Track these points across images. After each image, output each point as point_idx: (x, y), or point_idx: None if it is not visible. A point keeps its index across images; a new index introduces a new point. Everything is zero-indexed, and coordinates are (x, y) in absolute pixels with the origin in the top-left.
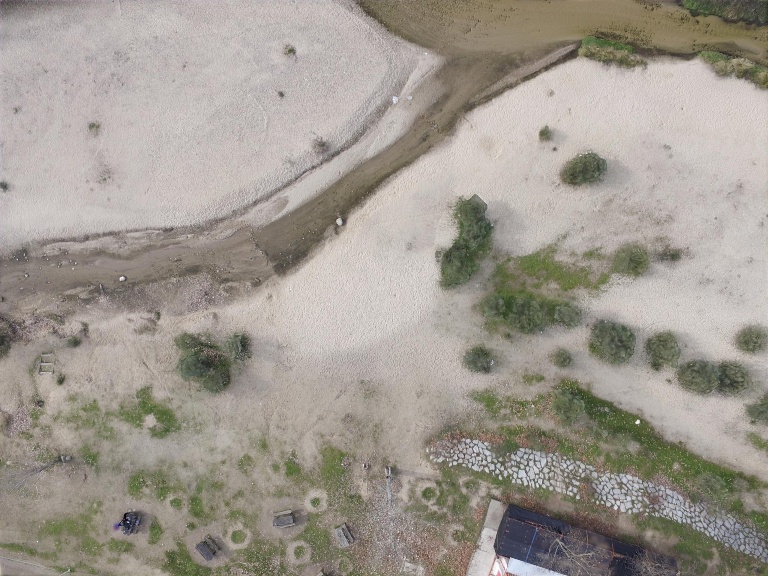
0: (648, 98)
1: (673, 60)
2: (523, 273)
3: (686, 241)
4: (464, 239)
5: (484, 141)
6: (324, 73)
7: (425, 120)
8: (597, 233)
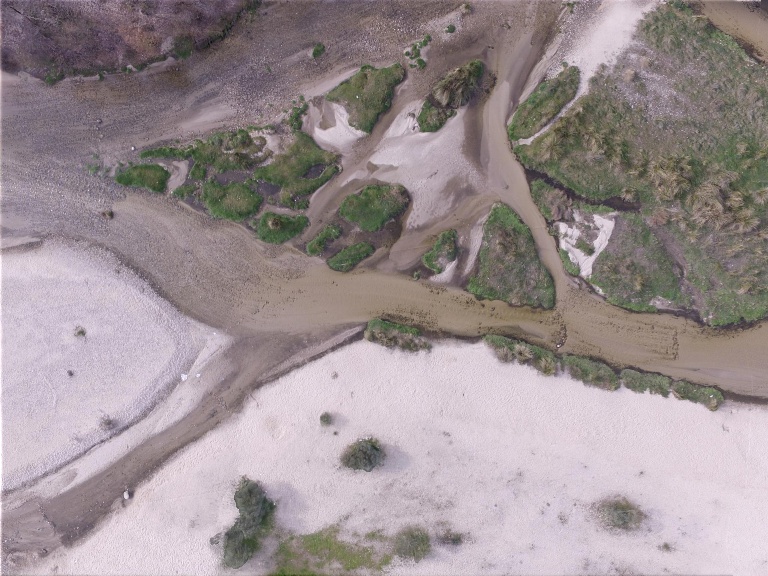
0: (430, 383)
1: (458, 343)
2: (306, 552)
3: (467, 526)
4: (238, 527)
5: (268, 421)
6: (112, 354)
7: (213, 397)
8: (379, 515)
